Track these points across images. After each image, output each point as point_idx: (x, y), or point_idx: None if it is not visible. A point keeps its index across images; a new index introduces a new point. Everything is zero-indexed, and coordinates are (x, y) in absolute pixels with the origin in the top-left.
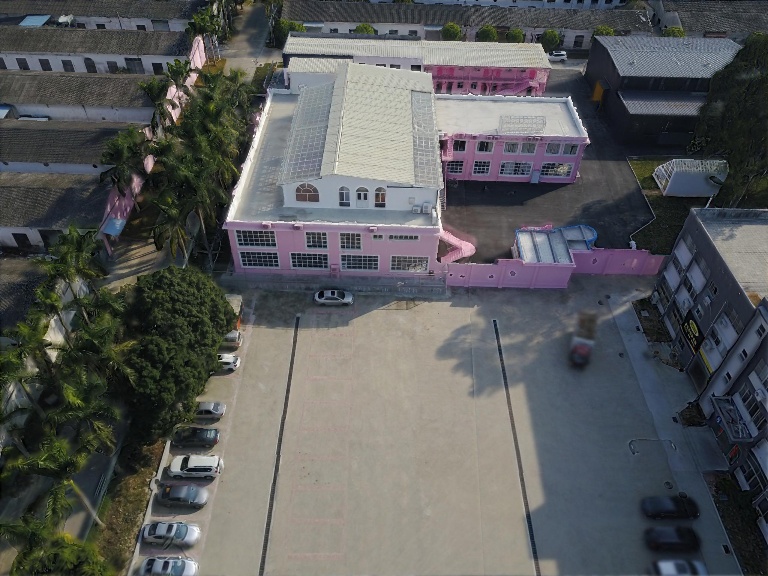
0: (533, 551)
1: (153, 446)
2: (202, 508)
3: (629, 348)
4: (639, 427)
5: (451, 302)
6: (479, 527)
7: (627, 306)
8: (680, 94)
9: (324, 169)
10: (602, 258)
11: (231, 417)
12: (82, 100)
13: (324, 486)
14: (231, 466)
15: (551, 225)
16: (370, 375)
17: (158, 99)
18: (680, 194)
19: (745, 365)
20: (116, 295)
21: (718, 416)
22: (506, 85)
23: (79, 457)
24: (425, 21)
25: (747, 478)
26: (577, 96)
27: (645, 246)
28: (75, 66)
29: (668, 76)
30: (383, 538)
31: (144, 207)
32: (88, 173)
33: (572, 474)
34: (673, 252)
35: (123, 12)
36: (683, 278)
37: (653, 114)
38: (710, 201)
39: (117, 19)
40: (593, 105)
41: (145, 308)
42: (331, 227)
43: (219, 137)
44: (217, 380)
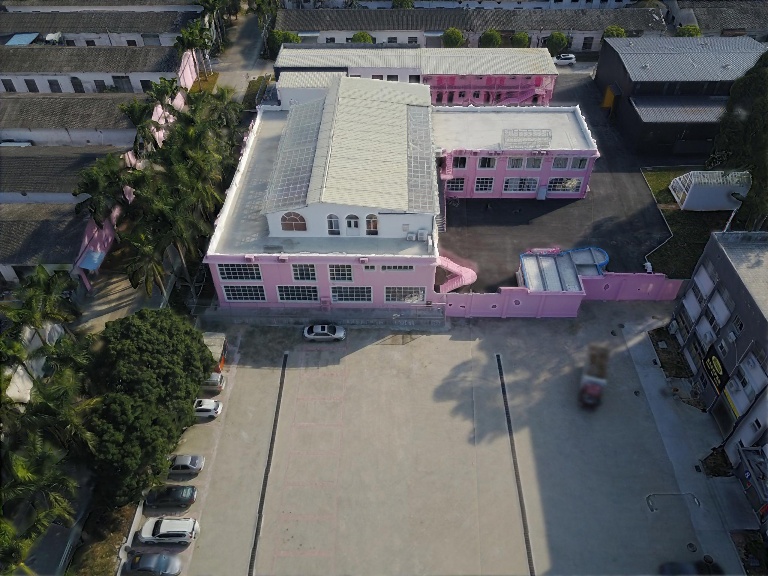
0: None
1: (124, 507)
2: None
3: (645, 385)
4: (658, 478)
5: (451, 335)
6: None
7: (643, 336)
8: (697, 98)
9: (310, 196)
10: (614, 284)
11: (210, 471)
12: (65, 123)
13: (309, 551)
14: (208, 528)
15: (558, 248)
16: (362, 421)
17: (140, 122)
18: (699, 208)
19: None
20: (79, 346)
21: (747, 471)
22: (510, 93)
23: (29, 538)
24: (425, 27)
25: None
26: (586, 102)
27: (662, 268)
28: (62, 86)
29: (684, 80)
30: None
31: None
32: (68, 202)
33: (583, 534)
34: (692, 279)
35: (112, 27)
36: (704, 309)
37: (668, 122)
38: (732, 217)
39: (106, 35)
40: (604, 112)
41: (110, 361)
42: (319, 259)
43: (198, 164)
44: (197, 429)
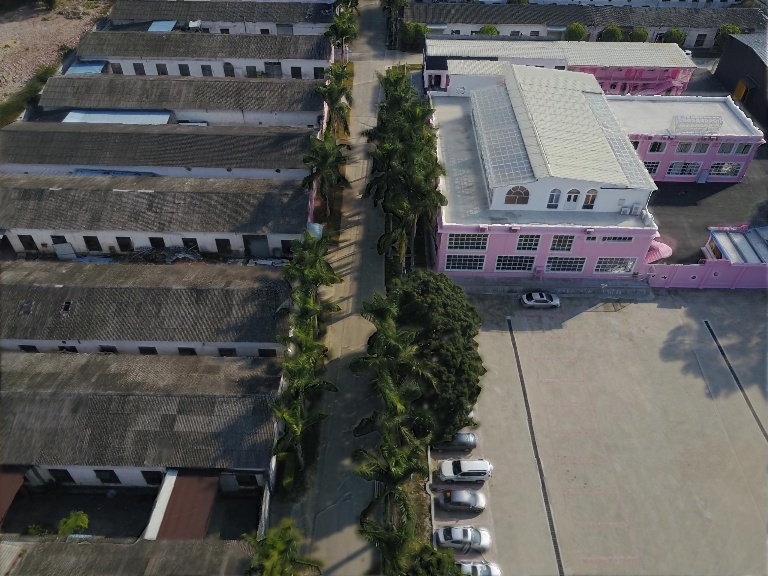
0: None
1: None
2: (482, 512)
3: None
4: None
5: (657, 303)
6: (764, 529)
7: None
8: None
9: (538, 171)
10: None
11: (478, 421)
12: (241, 105)
13: (595, 489)
14: (495, 470)
15: (745, 225)
16: (602, 377)
17: (335, 103)
18: None
19: None
20: (388, 300)
21: None
22: (648, 85)
23: None
24: (548, 22)
25: None
26: (714, 95)
27: None
28: (214, 71)
29: None
30: (673, 541)
31: (325, 211)
32: (269, 178)
33: None
34: None
35: (248, 16)
36: None
37: None
38: None
39: (242, 23)
40: None
41: (422, 313)
42: (547, 229)
43: (432, 140)
44: None
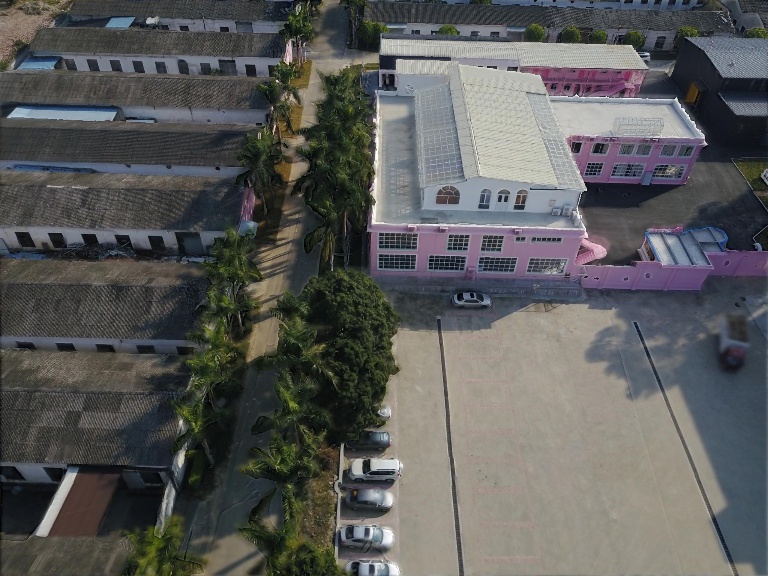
0: (727, 554)
1: (328, 449)
2: (389, 511)
3: None
4: None
5: (588, 304)
6: (668, 530)
7: (764, 308)
8: None
9: (467, 171)
10: (735, 260)
11: (396, 420)
12: (189, 102)
13: (505, 489)
14: (407, 469)
15: (680, 227)
16: (525, 378)
17: (277, 101)
18: None
19: None
20: (298, 298)
21: None
22: (601, 86)
23: (301, 461)
24: (508, 22)
25: None
26: (668, 97)
27: None
28: (168, 68)
29: None
30: (576, 541)
31: None
32: (209, 175)
33: (748, 477)
34: None
35: (207, 14)
36: None
37: (759, 115)
38: None
39: (201, 21)
40: (687, 106)
41: (331, 311)
42: (476, 229)
43: (363, 140)
44: None
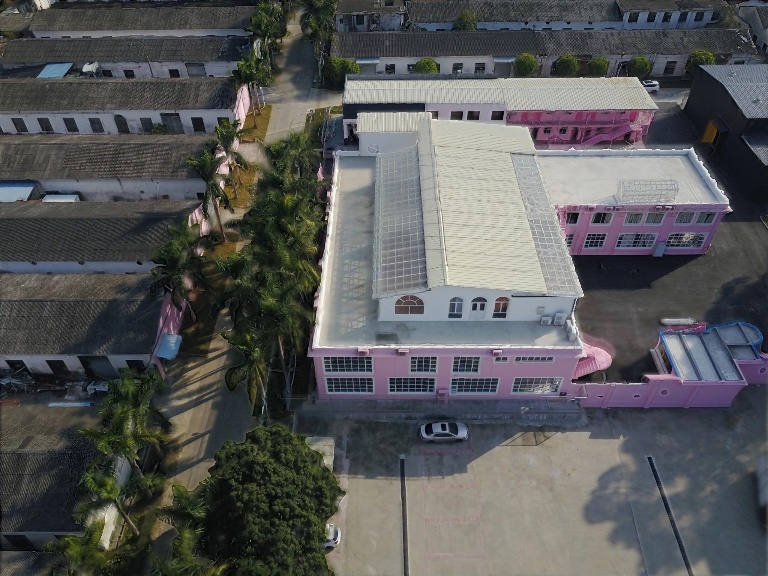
0: None
1: None
2: None
3: None
4: None
5: (590, 432)
6: None
7: None
8: None
9: (432, 277)
10: None
11: None
12: (117, 172)
13: None
14: None
15: None
16: (508, 550)
17: (210, 177)
18: None
19: None
20: (194, 493)
21: None
22: (602, 129)
23: None
24: (494, 52)
25: None
26: (682, 137)
27: None
28: (104, 124)
29: None
30: None
31: (198, 308)
32: (131, 270)
33: None
34: None
35: (153, 56)
36: None
37: None
38: None
39: (147, 64)
40: (704, 148)
41: (235, 515)
42: (444, 351)
43: (299, 241)
44: None
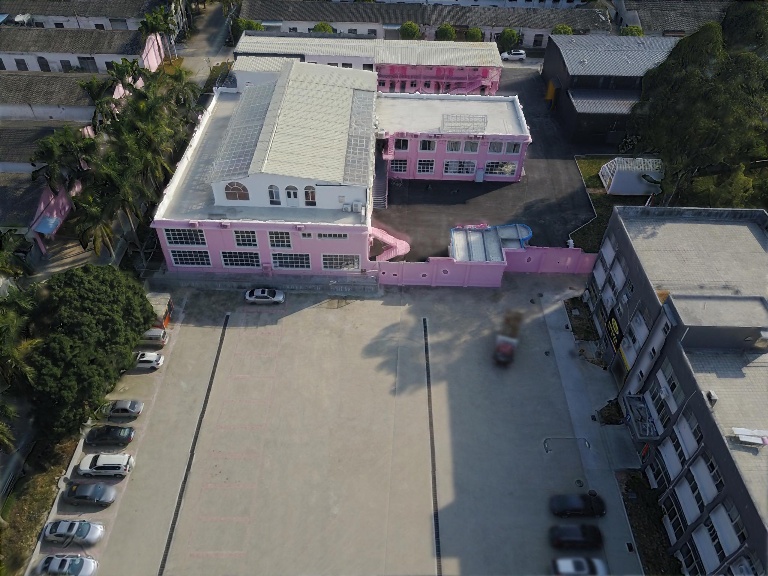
0: (437, 549)
1: (66, 444)
2: (109, 506)
3: (556, 346)
4: (556, 425)
5: (383, 300)
6: (385, 525)
7: (559, 304)
8: (630, 93)
9: (252, 167)
10: (536, 256)
11: (149, 415)
12: (28, 99)
13: (234, 484)
14: (143, 464)
15: None
16: (293, 373)
17: (98, 98)
18: (624, 193)
19: (654, 363)
20: (25, 293)
21: (628, 414)
22: (459, 84)
23: None
24: (384, 20)
25: (656, 476)
26: (531, 95)
27: (583, 245)
28: (28, 65)
29: (617, 75)
30: (287, 536)
31: None
32: (27, 172)
33: (484, 472)
34: (600, 250)
35: (81, 11)
36: (607, 276)
37: (600, 113)
38: (649, 200)
39: (75, 18)
40: (546, 104)
41: (52, 306)
42: (259, 225)
43: (147, 135)
44: (139, 378)
